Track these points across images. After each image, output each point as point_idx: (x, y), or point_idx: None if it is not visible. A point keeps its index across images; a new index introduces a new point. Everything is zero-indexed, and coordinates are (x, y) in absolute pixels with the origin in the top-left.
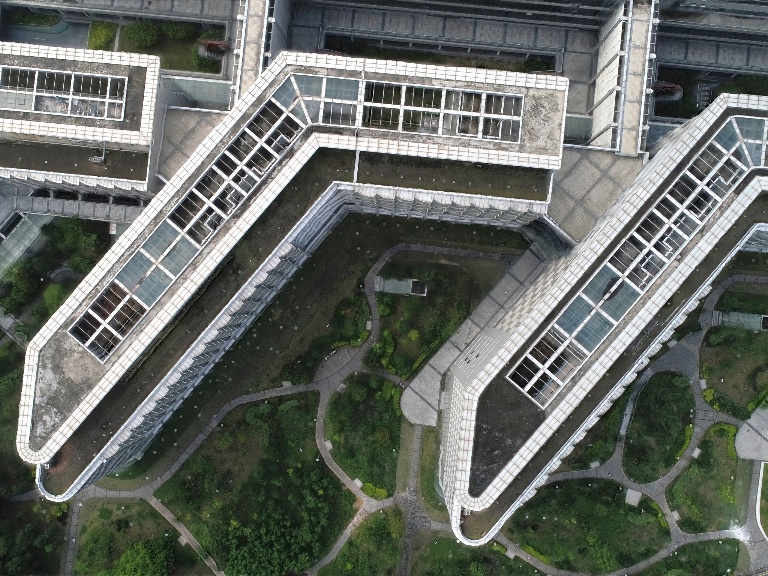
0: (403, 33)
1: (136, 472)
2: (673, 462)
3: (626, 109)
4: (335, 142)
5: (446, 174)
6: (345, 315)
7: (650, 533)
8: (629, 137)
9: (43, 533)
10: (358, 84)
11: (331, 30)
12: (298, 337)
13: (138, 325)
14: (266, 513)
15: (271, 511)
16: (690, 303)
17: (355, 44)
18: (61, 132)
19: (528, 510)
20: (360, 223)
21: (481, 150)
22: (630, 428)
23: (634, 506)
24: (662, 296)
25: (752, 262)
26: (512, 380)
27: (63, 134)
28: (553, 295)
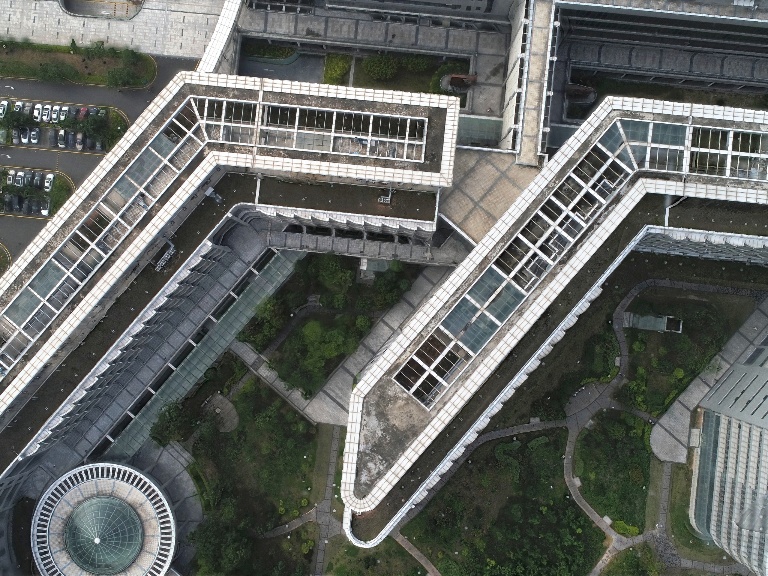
0: (651, 68)
1: None
2: None
3: None
4: (662, 188)
5: (759, 218)
6: (595, 351)
7: None
8: None
9: (295, 571)
10: (685, 129)
11: (578, 64)
12: (546, 373)
13: (463, 372)
14: (521, 551)
15: (527, 550)
16: None
17: (596, 78)
18: (360, 173)
19: None
20: None
21: None
22: None
23: None
24: None
25: None
26: None
27: (362, 175)
28: None
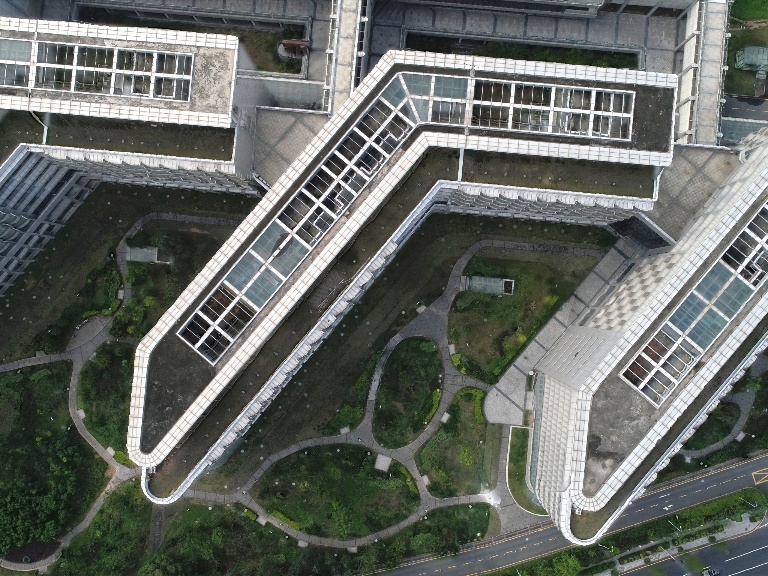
0: (153, 4)
1: None
2: (422, 427)
3: (338, 72)
4: (8, 103)
5: (133, 135)
6: (96, 284)
7: (399, 498)
8: (341, 100)
9: None
10: (31, 45)
11: (82, 1)
12: (51, 307)
13: None
14: (13, 481)
15: (17, 479)
16: (372, 260)
17: (112, 16)
18: None
19: (278, 476)
20: (112, 193)
21: (152, 109)
22: (379, 393)
23: (384, 471)
24: (330, 252)
25: (499, 227)
26: (182, 337)
27: None
28: (223, 252)
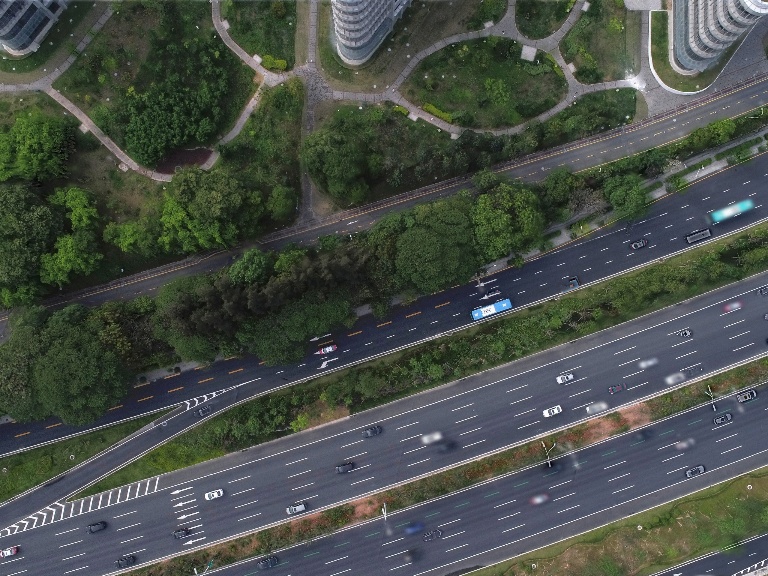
0: None
1: (33, 64)
2: (564, 15)
3: None
4: None
5: None
6: None
7: (548, 84)
8: None
9: None
10: None
11: None
12: None
13: None
14: (164, 82)
15: (169, 78)
16: None
17: None
18: None
19: (427, 70)
20: None
21: None
22: None
23: (530, 61)
24: None
25: None
26: None
27: None
28: None
